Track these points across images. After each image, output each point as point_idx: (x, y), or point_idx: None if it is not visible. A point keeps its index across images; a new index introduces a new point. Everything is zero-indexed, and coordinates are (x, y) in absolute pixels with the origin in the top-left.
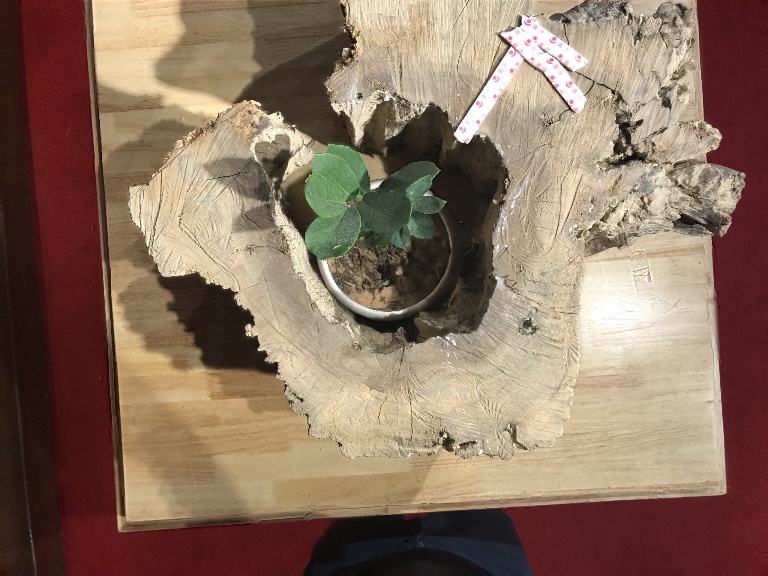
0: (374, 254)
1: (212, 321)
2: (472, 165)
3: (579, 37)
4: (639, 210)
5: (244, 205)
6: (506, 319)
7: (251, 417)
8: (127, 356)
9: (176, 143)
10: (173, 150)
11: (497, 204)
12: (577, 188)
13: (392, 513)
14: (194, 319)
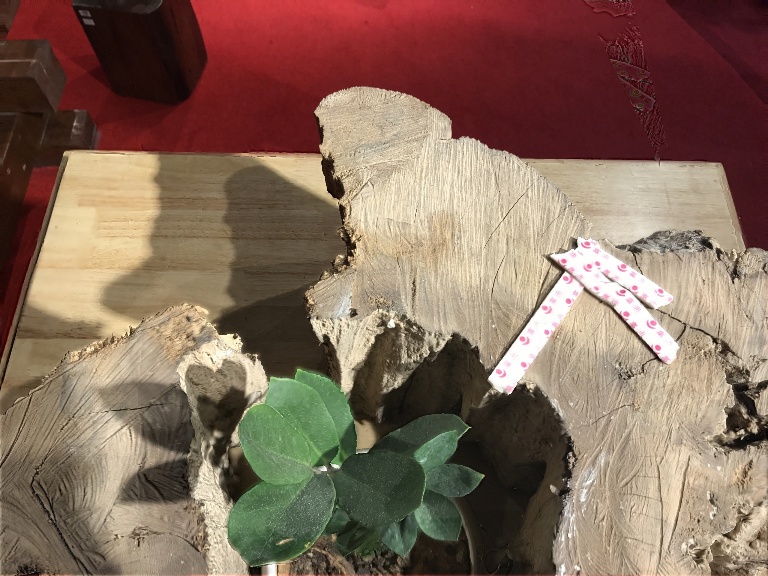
0: (351, 566)
1: None
2: (502, 439)
3: (656, 268)
4: None
5: (146, 457)
6: None
7: None
8: None
9: (68, 355)
10: (61, 364)
11: (557, 493)
12: (684, 477)
13: None
14: None
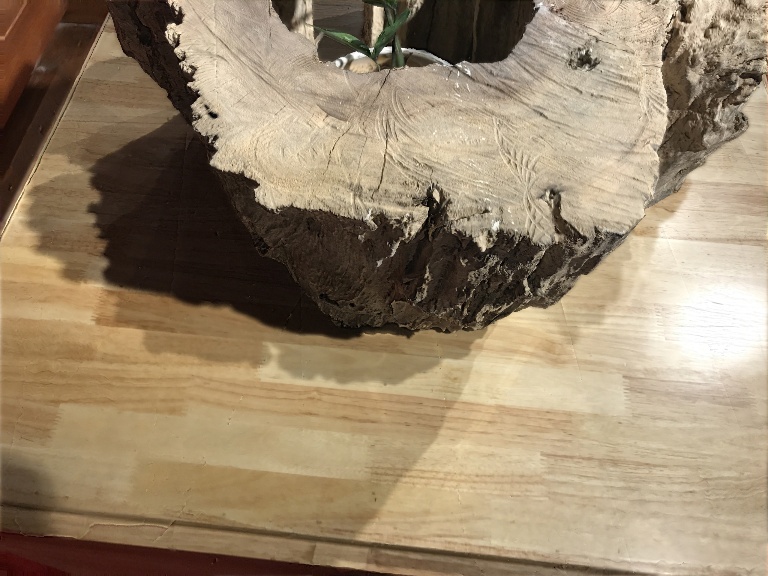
0: None
1: (138, 232)
2: None
3: None
4: (734, 7)
5: None
6: (550, 47)
7: (142, 356)
8: (8, 257)
9: None
10: None
11: None
12: None
13: (320, 563)
14: (116, 226)
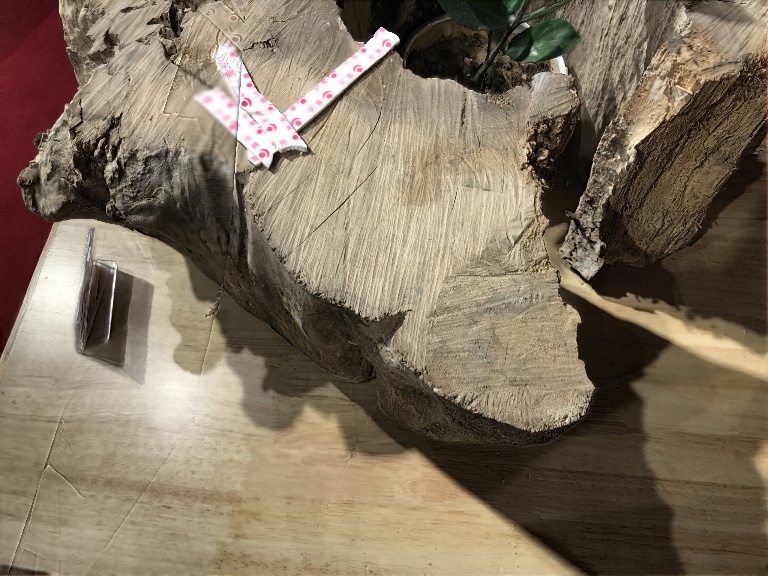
0: None
1: None
2: None
3: None
4: None
5: None
6: None
7: None
8: None
9: None
10: None
11: None
12: None
13: None
14: None
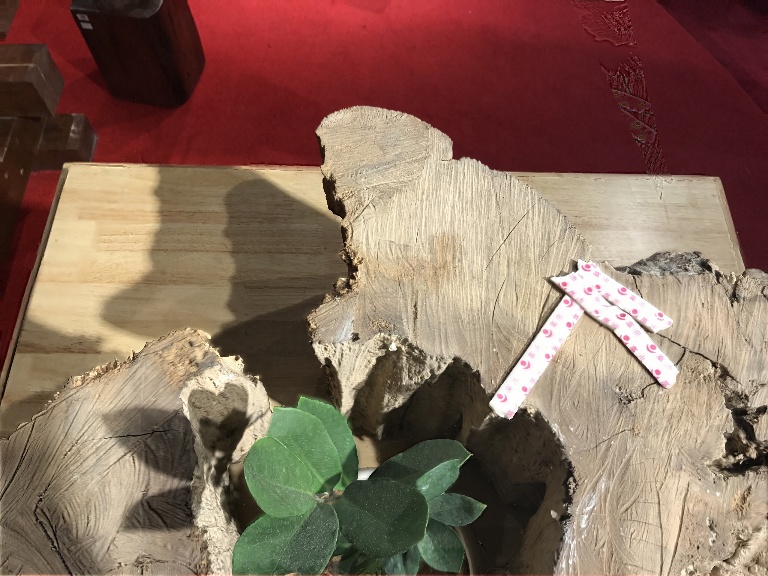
0: None
1: None
2: (502, 458)
3: (655, 291)
4: None
5: (149, 485)
6: None
7: None
8: None
9: (71, 379)
10: (64, 389)
11: (557, 519)
12: (684, 502)
13: None
14: None
